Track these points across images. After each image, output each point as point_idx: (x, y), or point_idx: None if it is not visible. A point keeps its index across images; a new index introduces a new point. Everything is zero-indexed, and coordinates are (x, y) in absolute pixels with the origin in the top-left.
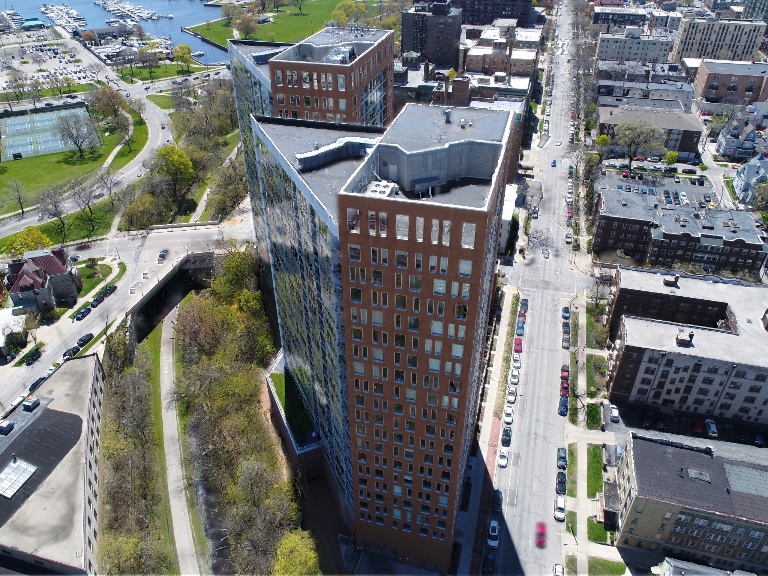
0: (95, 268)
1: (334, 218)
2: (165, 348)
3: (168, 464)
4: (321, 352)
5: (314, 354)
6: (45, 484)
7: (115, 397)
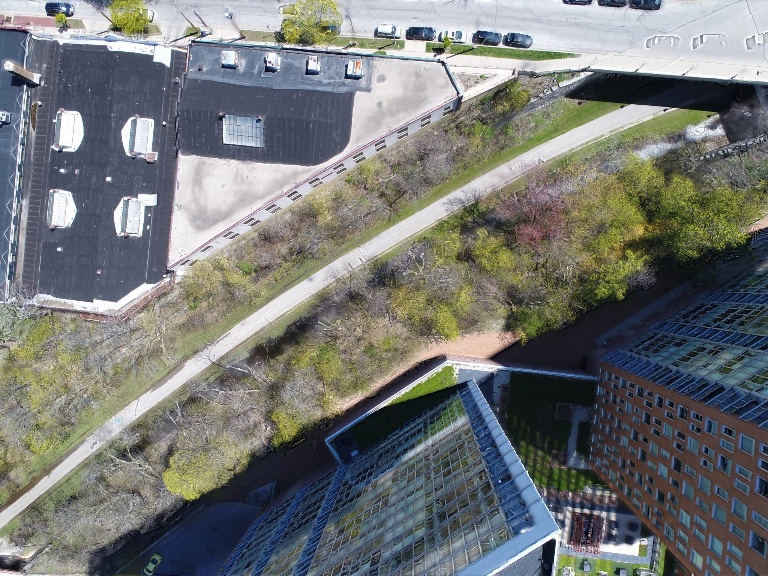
0: None
1: None
2: (562, 142)
3: (365, 245)
4: (264, 570)
5: (302, 535)
6: (251, 166)
7: (440, 134)
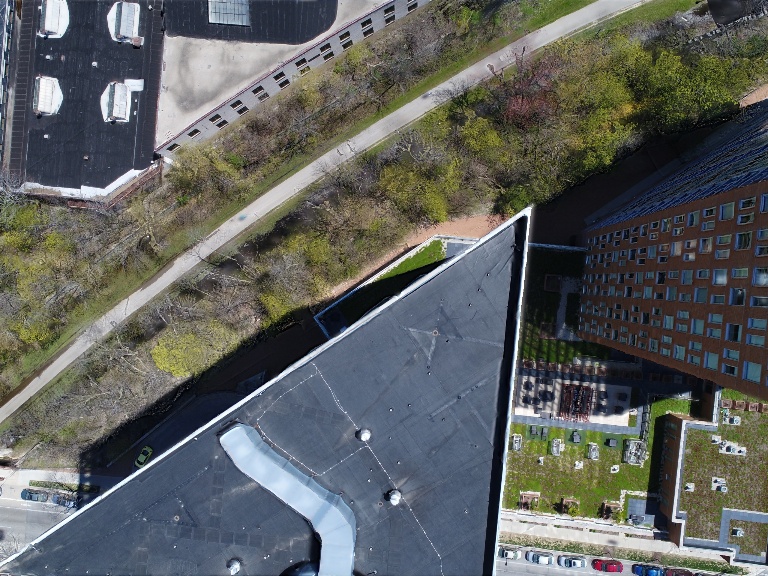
0: None
1: (41, 551)
2: (550, 31)
3: (354, 139)
4: None
5: None
6: (237, 46)
7: (427, 22)
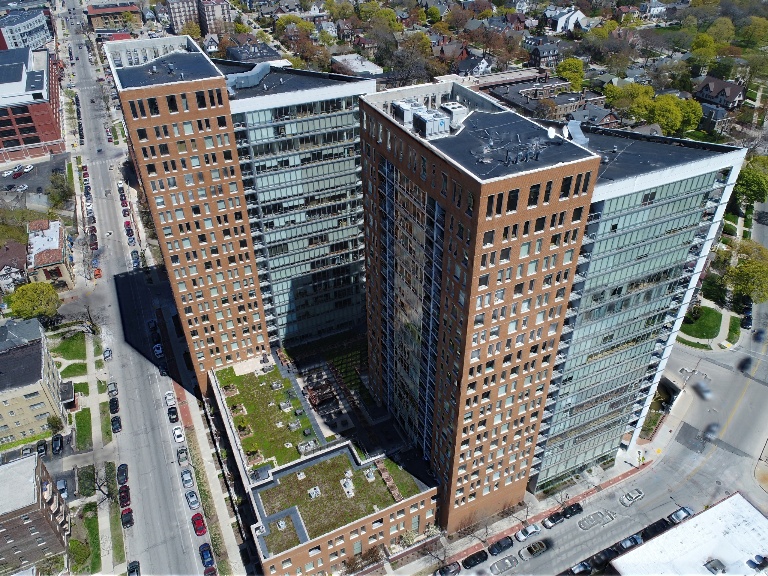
0: (705, 327)
1: None
2: None
3: None
4: None
5: None
6: None
7: None
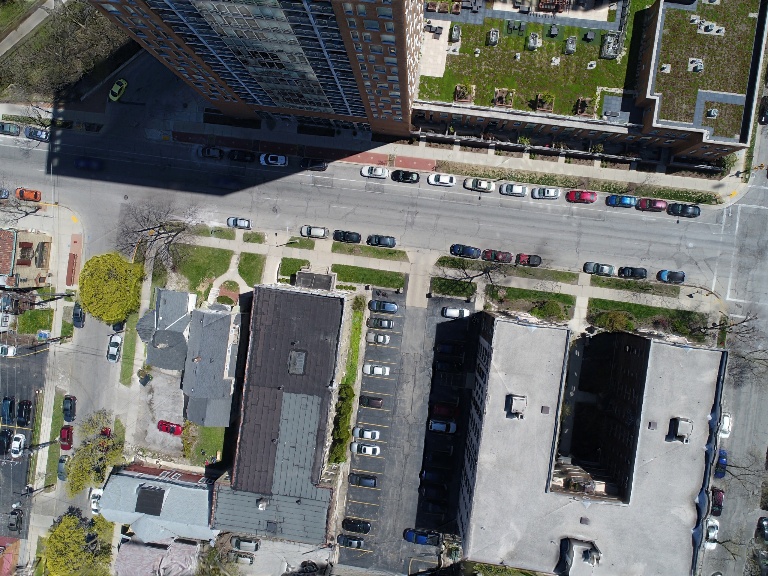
0: None
1: None
2: None
3: None
4: None
5: None
6: None
7: None
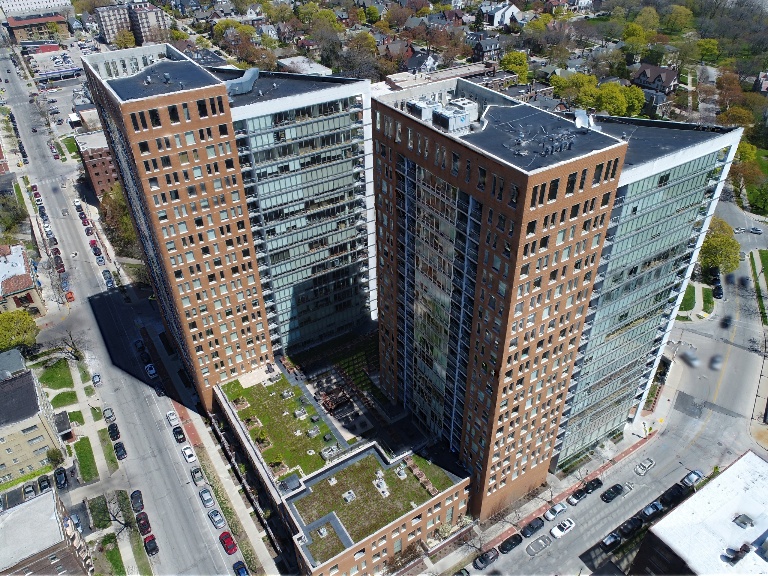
0: None
1: None
2: None
3: None
4: None
5: None
6: None
7: None
